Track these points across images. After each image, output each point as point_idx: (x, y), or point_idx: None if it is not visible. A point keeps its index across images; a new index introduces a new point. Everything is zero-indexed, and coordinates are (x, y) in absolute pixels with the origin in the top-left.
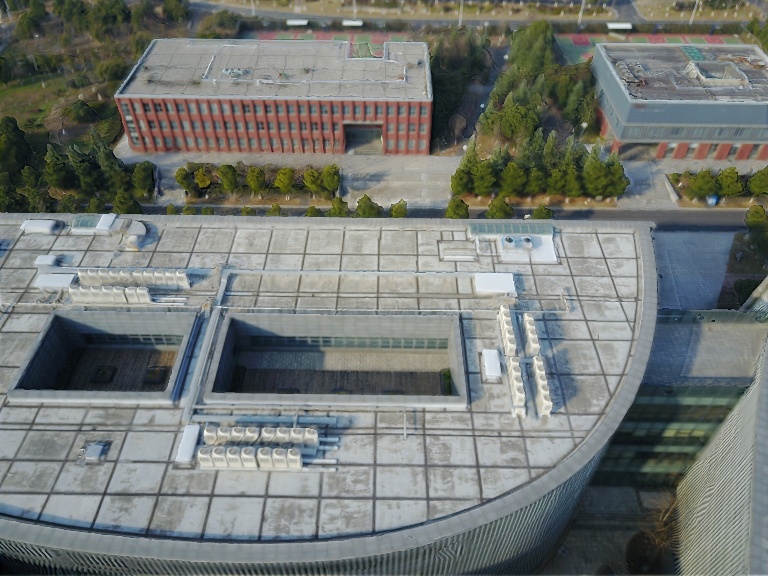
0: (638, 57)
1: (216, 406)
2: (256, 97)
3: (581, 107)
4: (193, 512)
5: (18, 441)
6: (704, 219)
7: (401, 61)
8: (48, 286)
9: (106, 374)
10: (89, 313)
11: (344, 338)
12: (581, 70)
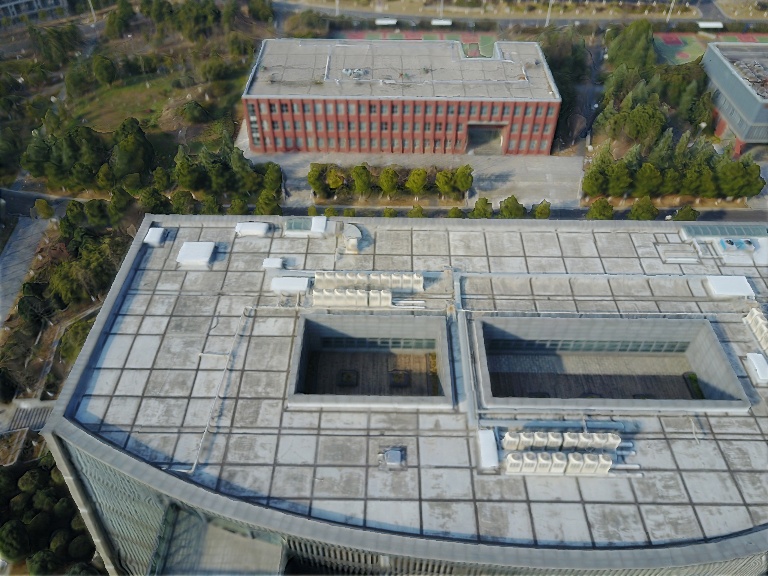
0: (753, 57)
1: (499, 411)
2: (384, 97)
3: (695, 107)
4: (517, 518)
5: (312, 446)
6: None
7: (517, 61)
8: (285, 289)
9: (351, 378)
10: (338, 317)
11: (584, 341)
12: (694, 70)
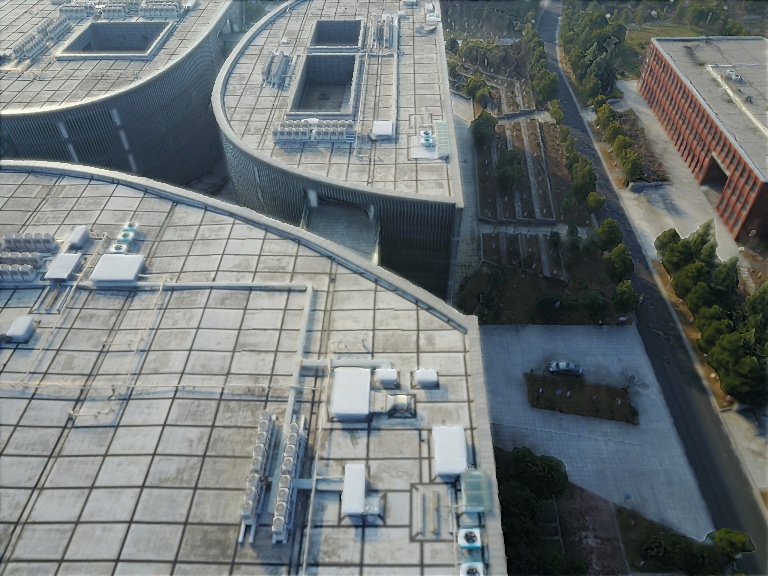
0: None
1: None
2: (692, 89)
3: None
4: (249, 61)
5: (294, 29)
6: (738, 512)
7: None
8: None
9: None
10: None
11: None
12: None
